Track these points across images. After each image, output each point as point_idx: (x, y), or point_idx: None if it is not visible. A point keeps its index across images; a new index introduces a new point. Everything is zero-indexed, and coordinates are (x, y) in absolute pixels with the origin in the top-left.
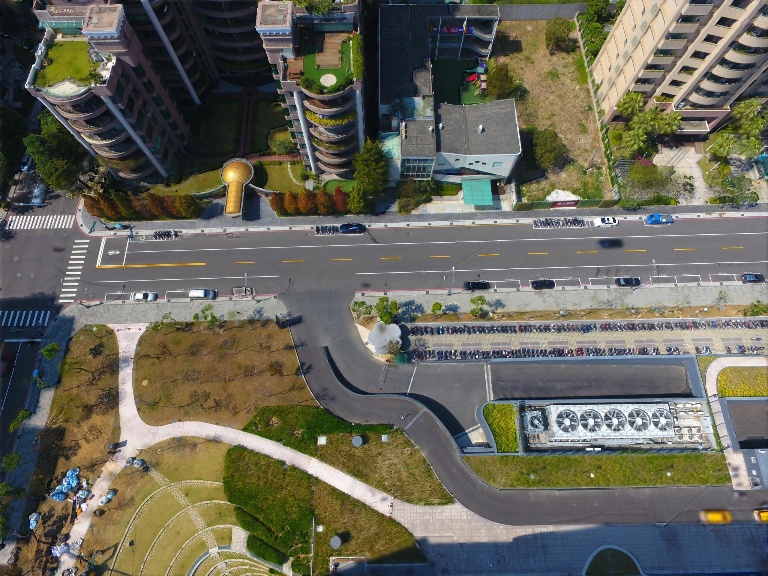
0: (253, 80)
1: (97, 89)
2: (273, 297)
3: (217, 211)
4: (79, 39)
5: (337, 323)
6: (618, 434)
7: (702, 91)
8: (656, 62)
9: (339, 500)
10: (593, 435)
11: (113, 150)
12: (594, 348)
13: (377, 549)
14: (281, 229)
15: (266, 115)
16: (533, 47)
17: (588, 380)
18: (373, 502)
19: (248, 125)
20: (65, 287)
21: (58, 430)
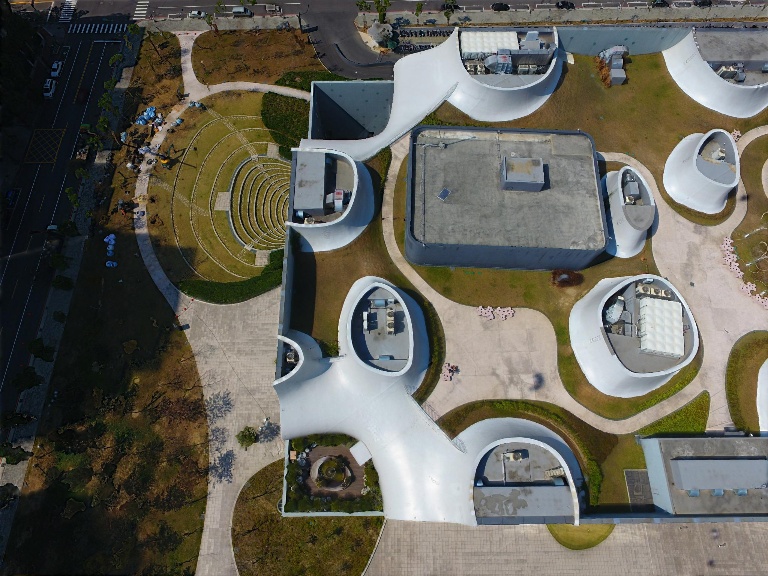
0: None
1: None
2: (296, 16)
3: None
4: None
5: (344, 31)
6: None
7: None
8: None
9: None
10: None
11: None
12: None
13: None
14: None
15: None
16: None
17: None
18: None
19: None
20: (137, 10)
21: (138, 90)
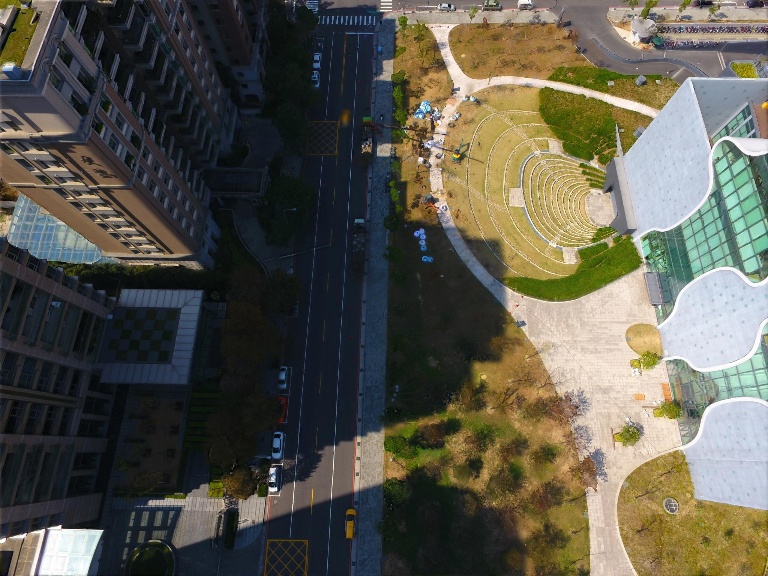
0: None
1: None
2: (546, 10)
3: None
4: None
5: (599, 26)
6: None
7: None
8: None
9: (633, 115)
10: None
11: None
12: None
13: None
14: None
15: None
16: None
17: None
18: None
19: None
20: (383, 2)
21: (404, 83)
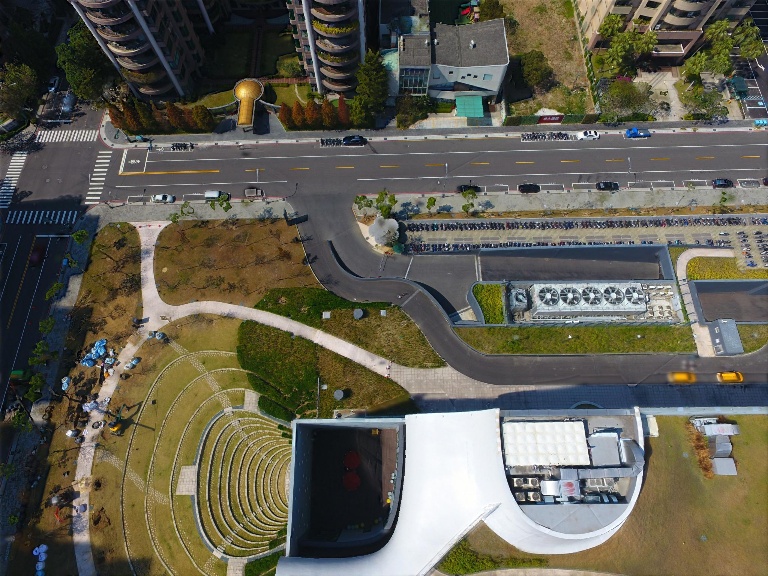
0: (263, 14)
1: None
2: (281, 199)
3: (230, 126)
4: None
5: (340, 221)
6: (595, 308)
7: (676, 12)
8: None
9: (342, 363)
10: (572, 308)
11: (136, 62)
12: (575, 241)
13: (376, 403)
14: (289, 142)
15: (275, 44)
16: None
17: (570, 272)
18: (372, 365)
19: (258, 52)
20: (91, 191)
21: (86, 310)
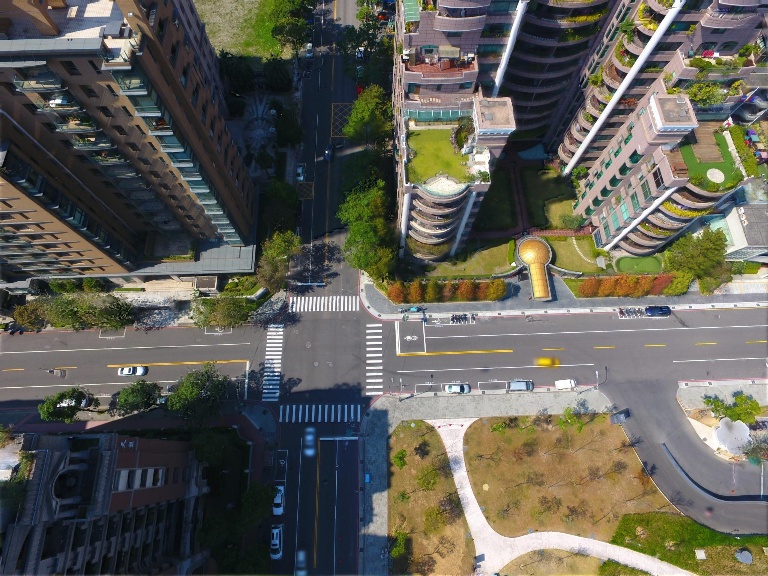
0: (511, 145)
1: (478, 186)
2: None
3: (511, 291)
4: (435, 127)
5: (668, 417)
6: None
7: None
8: None
9: None
10: None
11: (434, 236)
12: None
13: None
14: (582, 311)
15: (536, 185)
16: None
17: None
18: None
19: (520, 196)
20: (369, 377)
21: (404, 542)
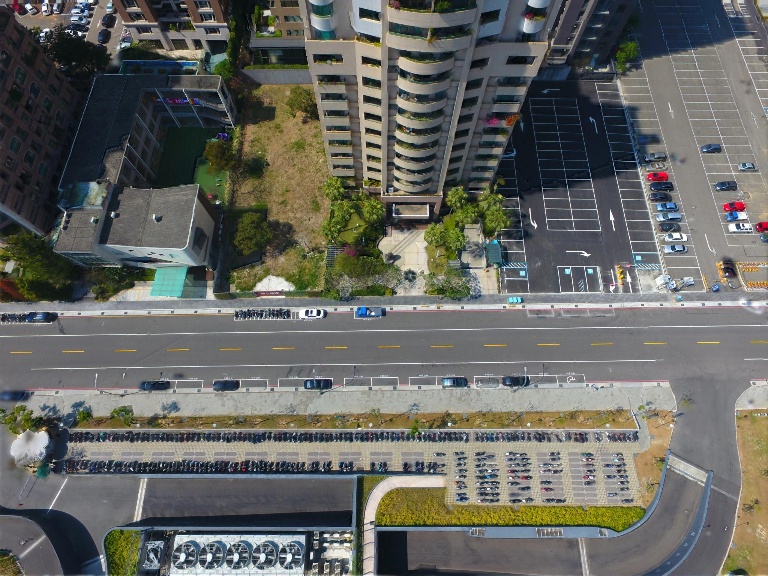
0: None
1: None
2: None
3: None
4: None
5: None
6: (240, 571)
7: None
8: (335, 151)
9: None
10: (212, 572)
11: None
12: (260, 462)
13: None
14: None
15: None
16: (287, 114)
17: (256, 496)
18: None
19: None
20: None
21: None
